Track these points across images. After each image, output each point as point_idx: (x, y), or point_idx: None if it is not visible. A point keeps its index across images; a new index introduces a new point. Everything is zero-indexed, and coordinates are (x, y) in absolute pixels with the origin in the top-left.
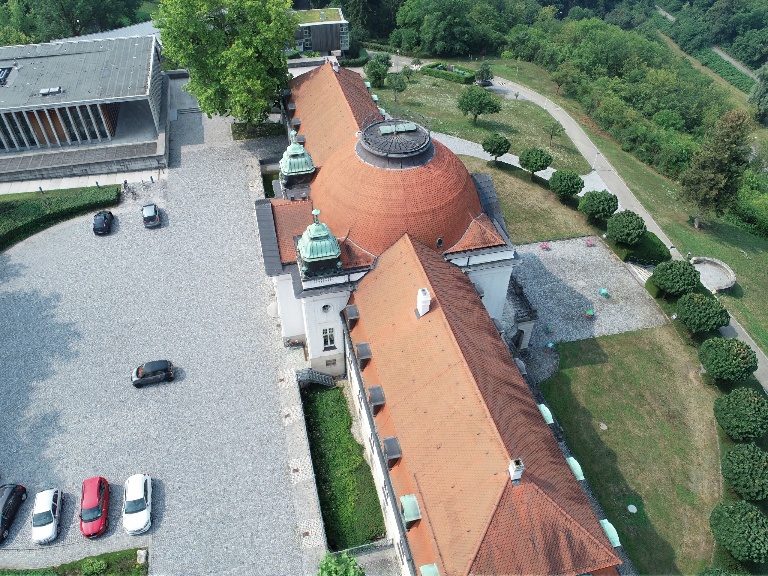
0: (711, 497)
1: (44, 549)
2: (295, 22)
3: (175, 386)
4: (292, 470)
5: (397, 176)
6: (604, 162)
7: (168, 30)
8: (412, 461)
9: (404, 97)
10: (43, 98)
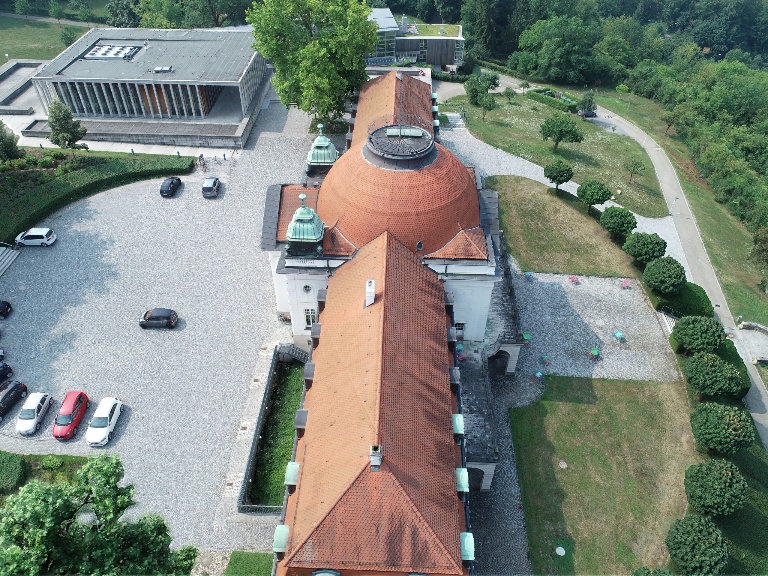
0: (653, 563)
1: (23, 439)
2: (372, 29)
3: (173, 334)
4: (241, 427)
5: (389, 176)
6: (686, 209)
7: (257, 25)
8: (309, 433)
9: (496, 116)
10: (155, 75)
